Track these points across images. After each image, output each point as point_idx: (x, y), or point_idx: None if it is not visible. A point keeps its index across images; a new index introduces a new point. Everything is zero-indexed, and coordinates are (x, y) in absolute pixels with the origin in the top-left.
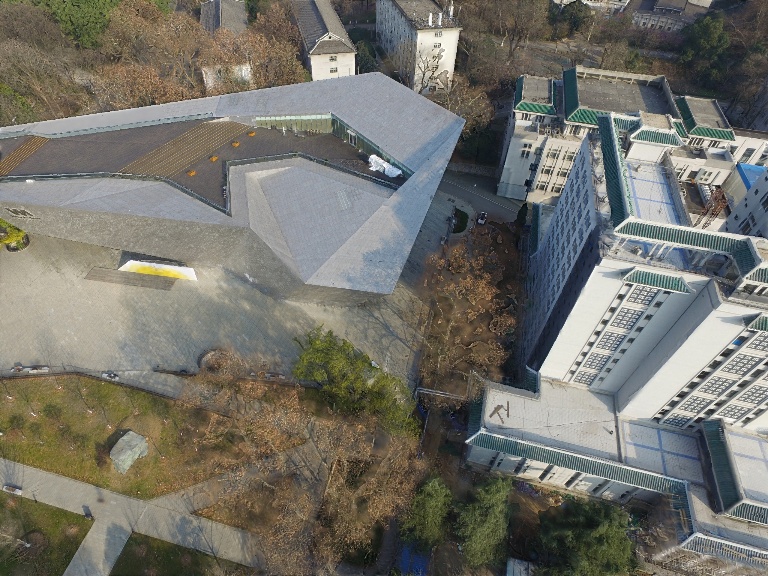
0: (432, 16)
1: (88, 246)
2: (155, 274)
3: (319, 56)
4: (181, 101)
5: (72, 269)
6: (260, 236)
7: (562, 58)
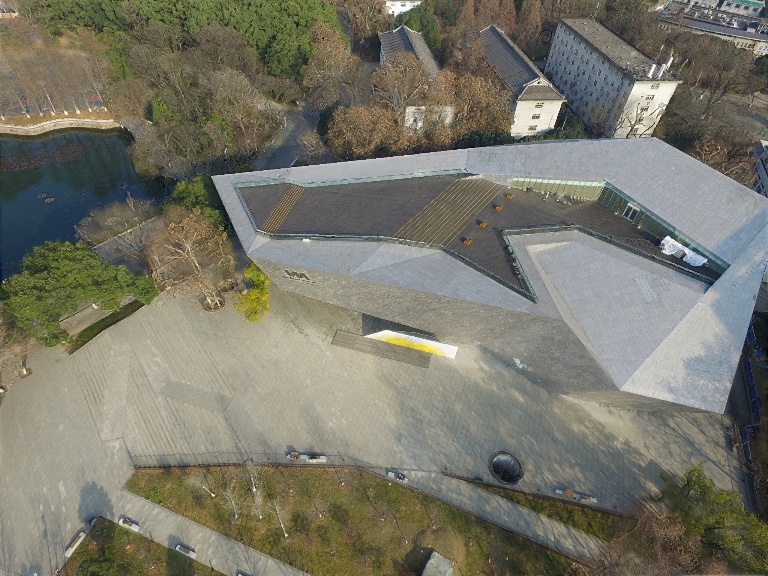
0: (645, 65)
1: (323, 303)
2: (407, 346)
3: (527, 102)
4: (429, 153)
5: (315, 330)
6: (573, 330)
7: (759, 114)
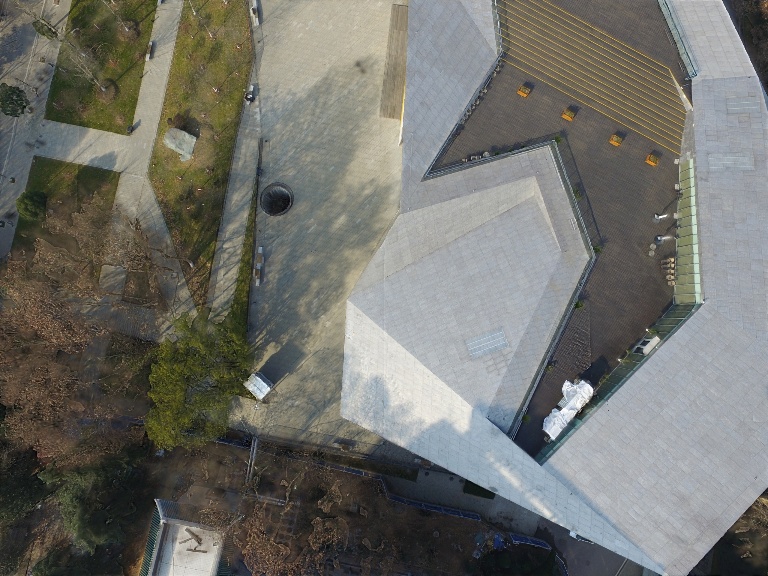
0: None
1: None
2: None
3: None
4: None
5: None
6: (393, 230)
7: None
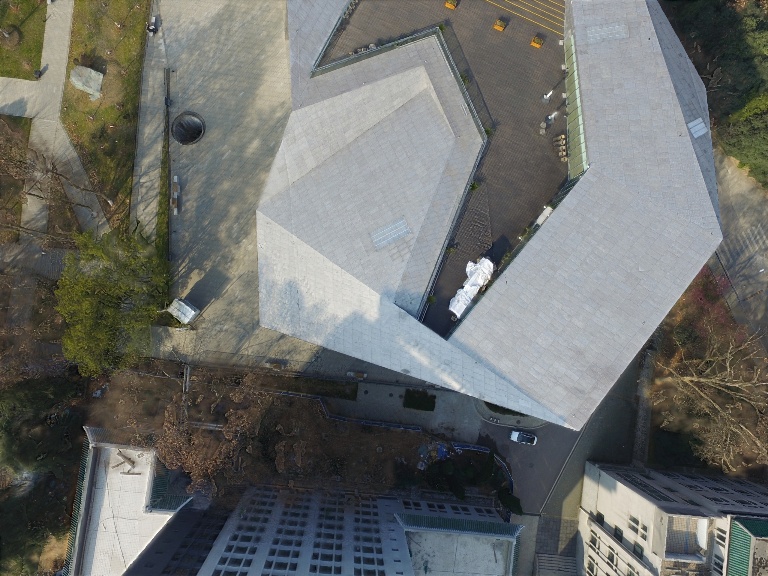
0: None
1: None
2: None
3: None
4: None
5: None
6: (288, 130)
7: None
